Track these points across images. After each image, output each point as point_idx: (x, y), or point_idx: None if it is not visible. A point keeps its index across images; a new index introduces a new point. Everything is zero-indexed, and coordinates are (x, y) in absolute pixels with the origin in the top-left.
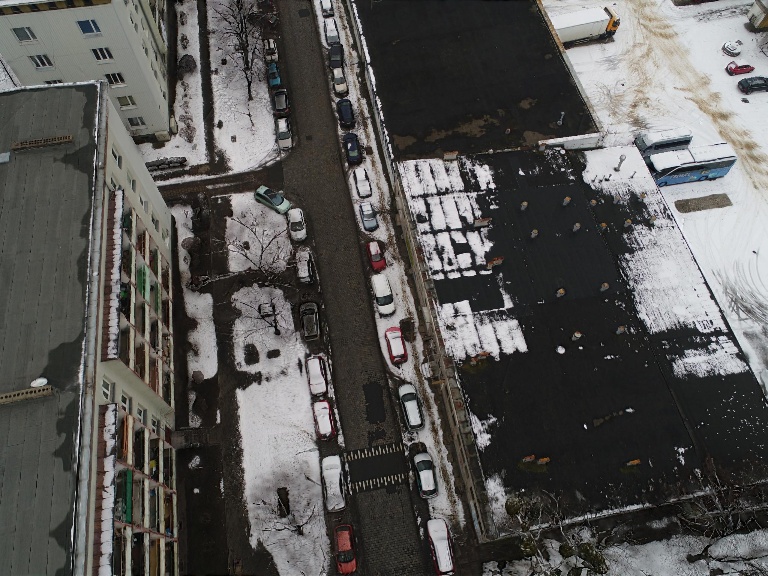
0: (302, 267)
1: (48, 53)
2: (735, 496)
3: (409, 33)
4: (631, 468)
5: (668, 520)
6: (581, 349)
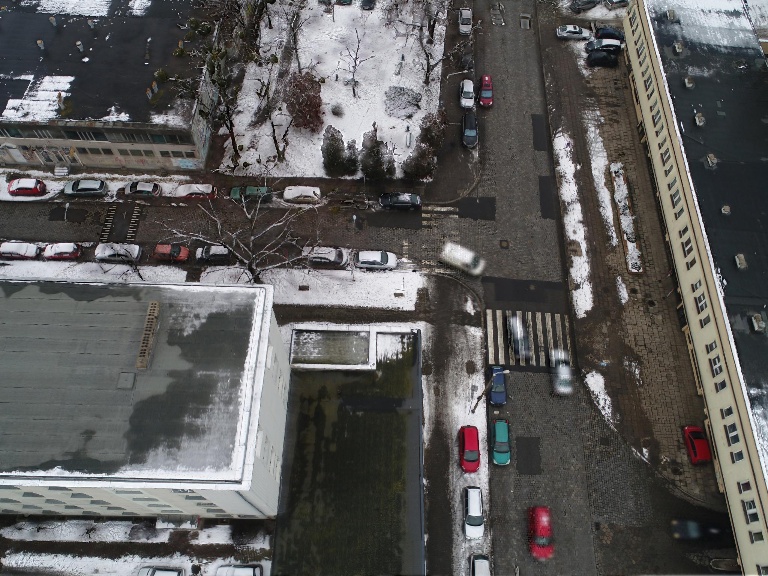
0: None
1: None
2: (230, 20)
3: None
4: None
5: (235, 68)
6: (92, 49)
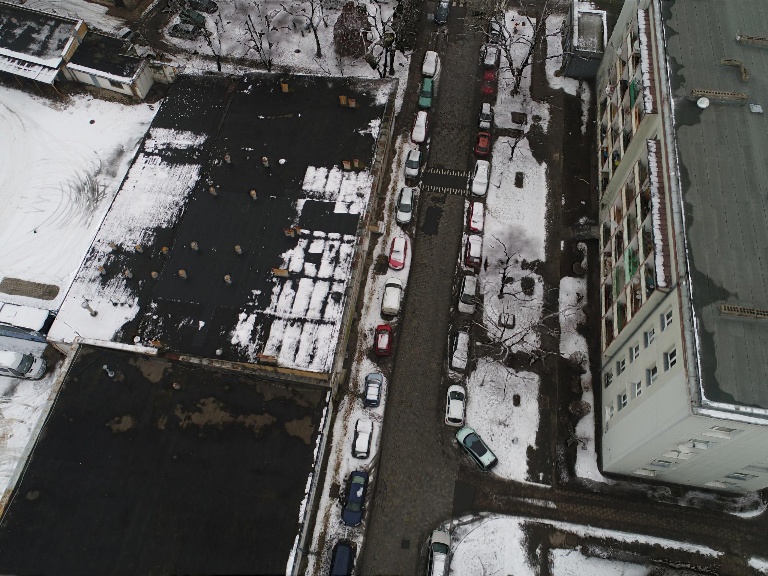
0: (464, 344)
1: None
2: None
3: None
4: None
5: None
6: None
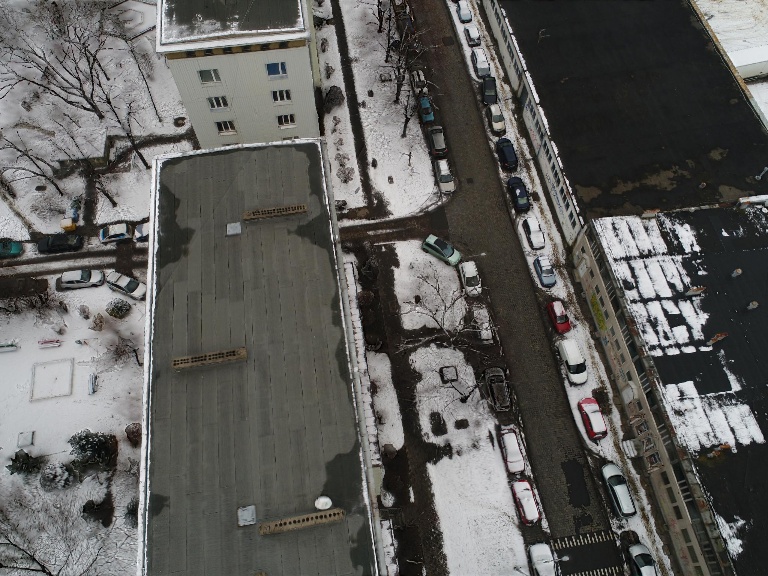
0: None
1: (228, 95)
2: None
3: (577, 70)
4: None
5: None
6: None
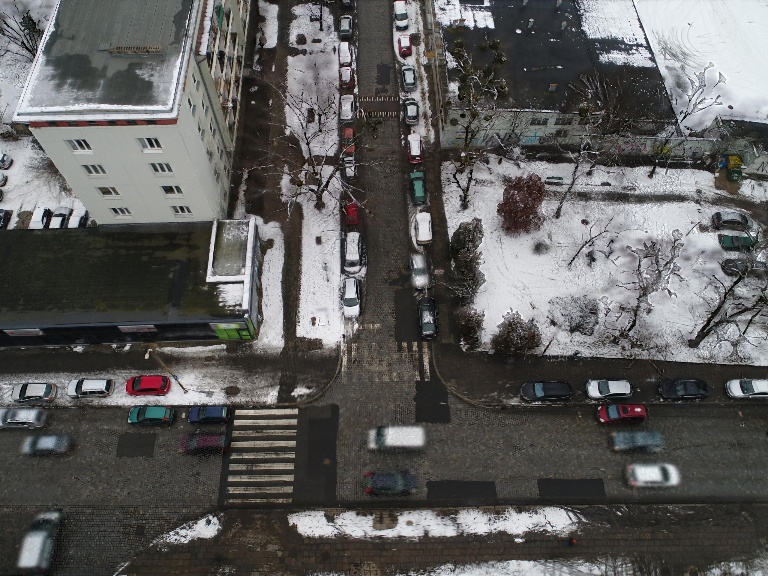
0: None
1: None
2: None
3: None
4: (552, 93)
5: None
6: (533, 33)
